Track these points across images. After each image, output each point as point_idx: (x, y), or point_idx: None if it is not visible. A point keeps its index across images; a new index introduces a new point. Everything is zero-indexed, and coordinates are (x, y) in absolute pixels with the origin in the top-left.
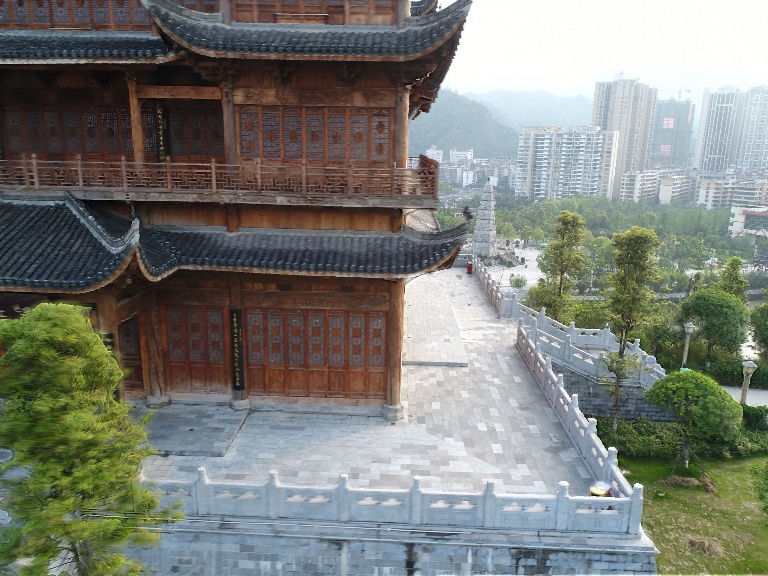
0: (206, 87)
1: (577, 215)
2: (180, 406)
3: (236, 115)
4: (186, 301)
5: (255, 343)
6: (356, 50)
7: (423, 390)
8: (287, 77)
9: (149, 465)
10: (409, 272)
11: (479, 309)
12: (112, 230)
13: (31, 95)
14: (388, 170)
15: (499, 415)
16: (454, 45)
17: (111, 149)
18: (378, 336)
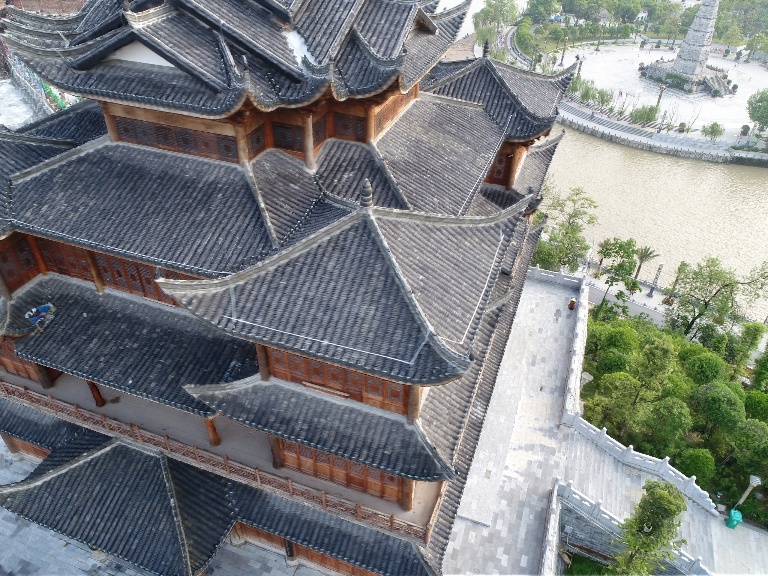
0: None
1: (670, 346)
2: (252, 548)
3: None
4: None
5: None
6: (359, 461)
7: None
8: None
9: None
10: None
11: (547, 402)
12: (190, 490)
13: None
14: None
15: None
16: None
17: None
18: None
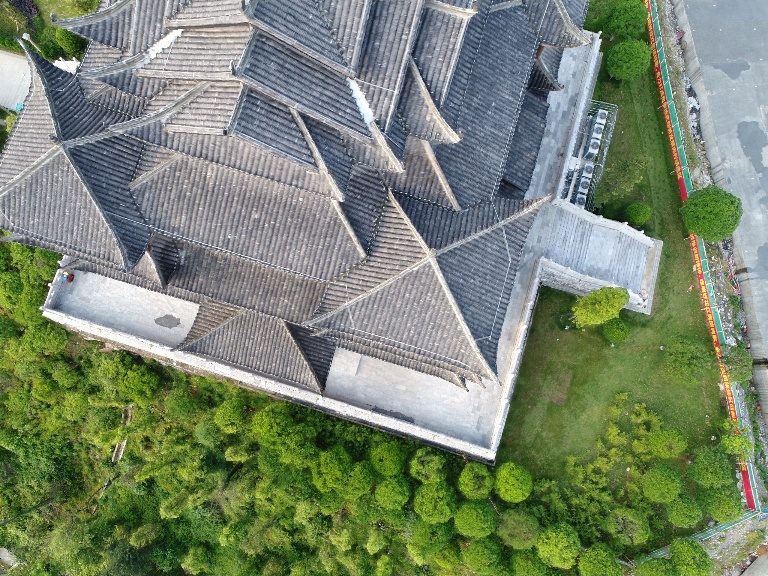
0: None
1: (8, 119)
2: None
3: None
4: None
5: None
6: None
7: None
8: None
9: None
10: None
11: None
12: None
13: None
14: None
15: None
16: None
17: None
18: None
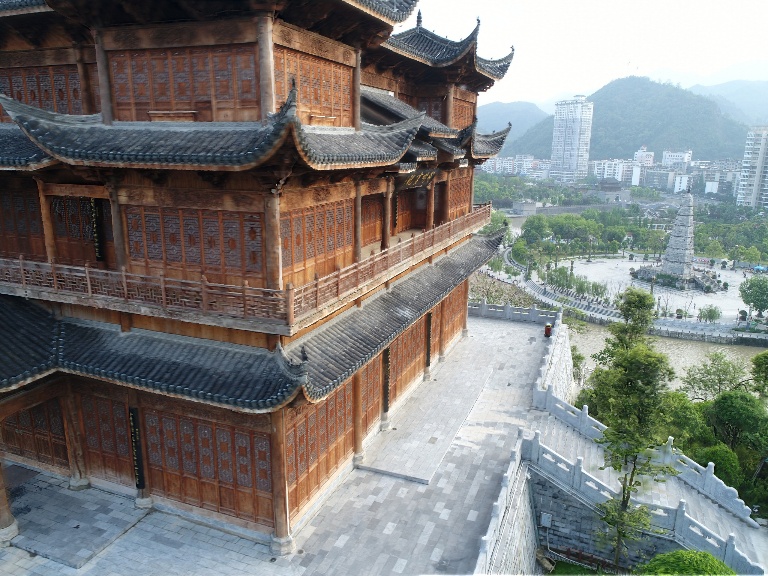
0: (97, 186)
1: None
2: (95, 492)
3: (123, 215)
4: (95, 392)
5: (153, 443)
6: (191, 159)
7: (347, 513)
8: (161, 178)
9: (11, 564)
10: (255, 407)
11: (515, 393)
12: (6, 327)
13: (3, 181)
14: (239, 289)
15: (402, 572)
16: (297, 151)
17: (61, 233)
18: (263, 459)
